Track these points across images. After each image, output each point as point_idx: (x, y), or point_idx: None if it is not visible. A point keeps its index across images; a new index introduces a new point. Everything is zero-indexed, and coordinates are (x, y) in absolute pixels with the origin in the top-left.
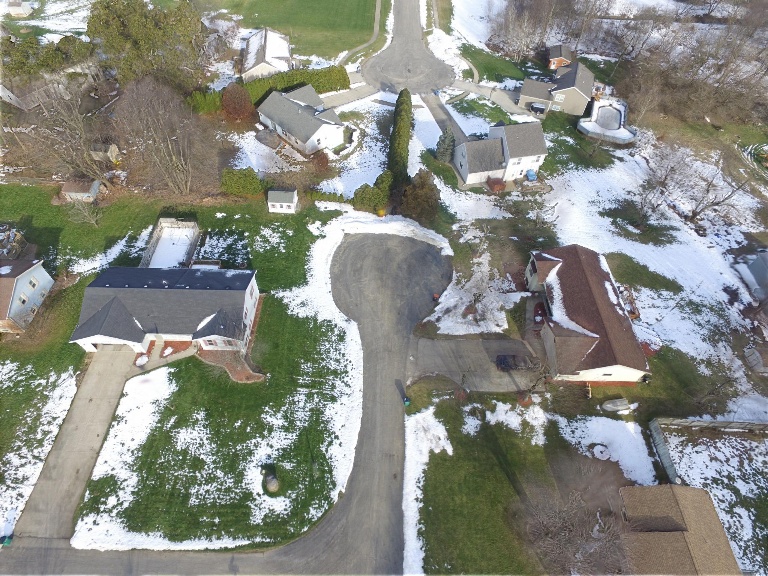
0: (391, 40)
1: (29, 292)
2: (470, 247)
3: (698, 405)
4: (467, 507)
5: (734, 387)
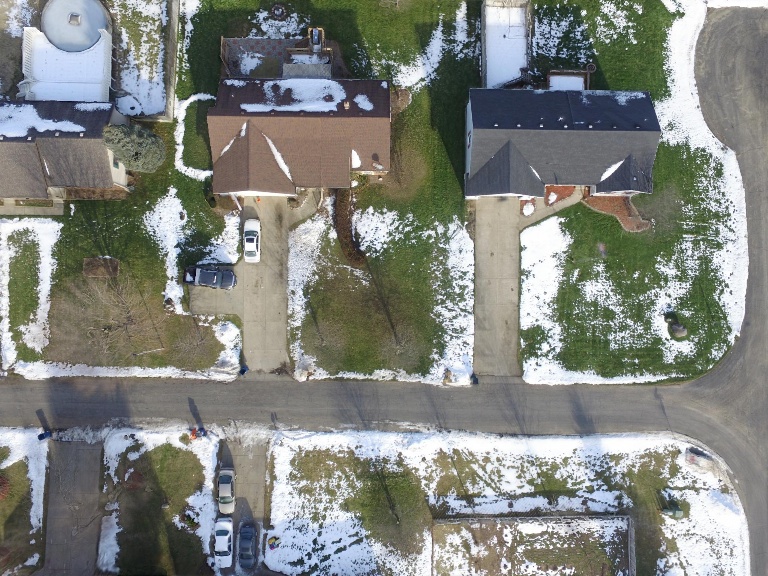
0: None
1: None
2: None
3: None
4: None
5: None
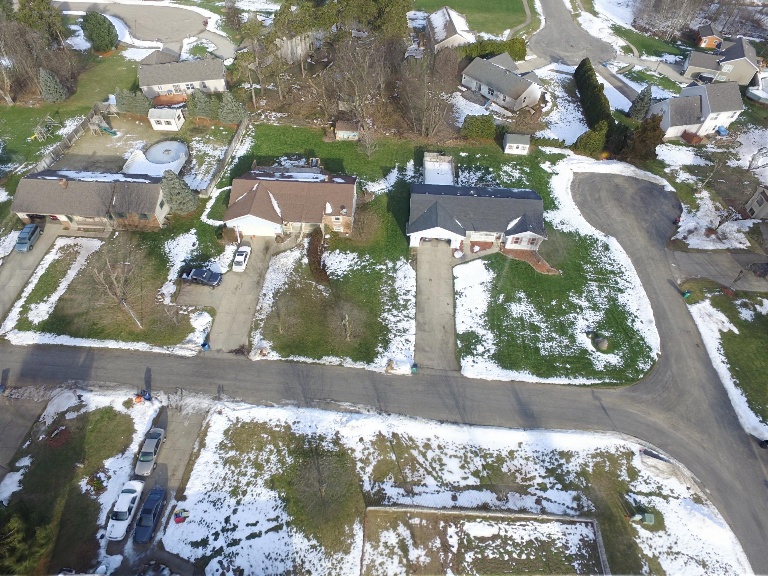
0: (545, 21)
1: (353, 200)
2: (688, 186)
3: None
4: None
5: None
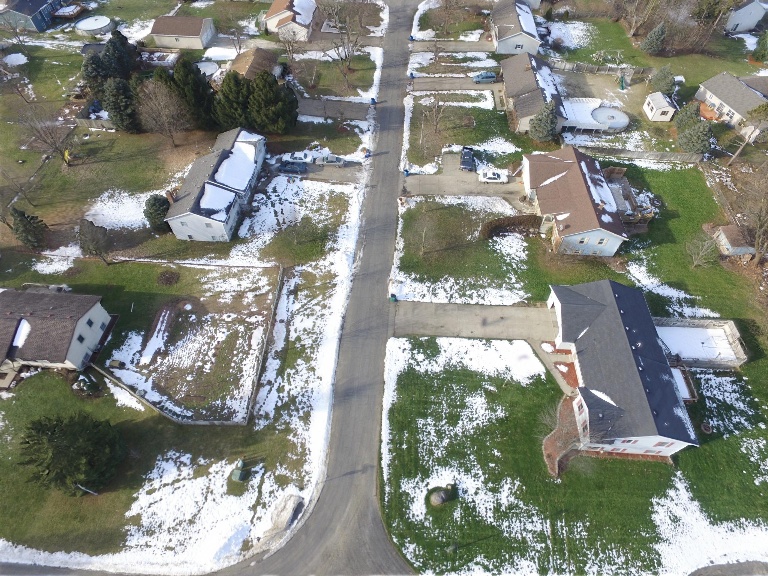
0: None
1: (592, 242)
2: None
3: None
4: None
5: None
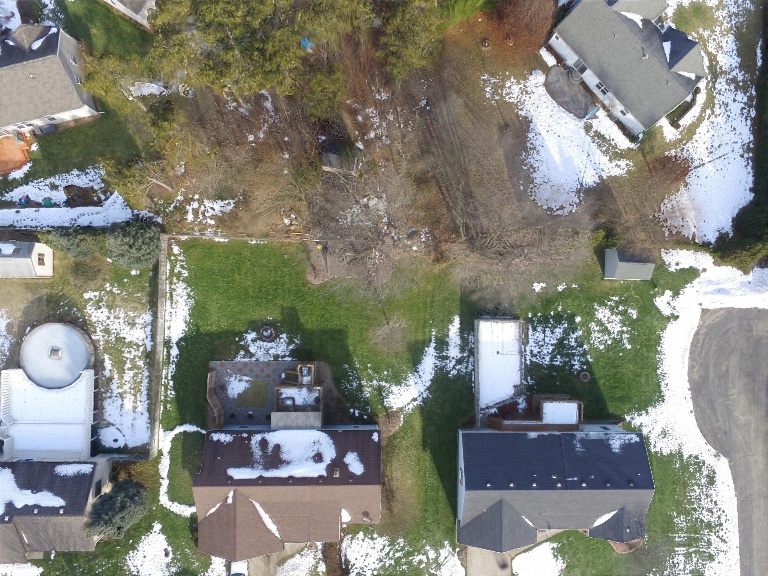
0: None
1: None
2: None
3: None
4: None
5: None
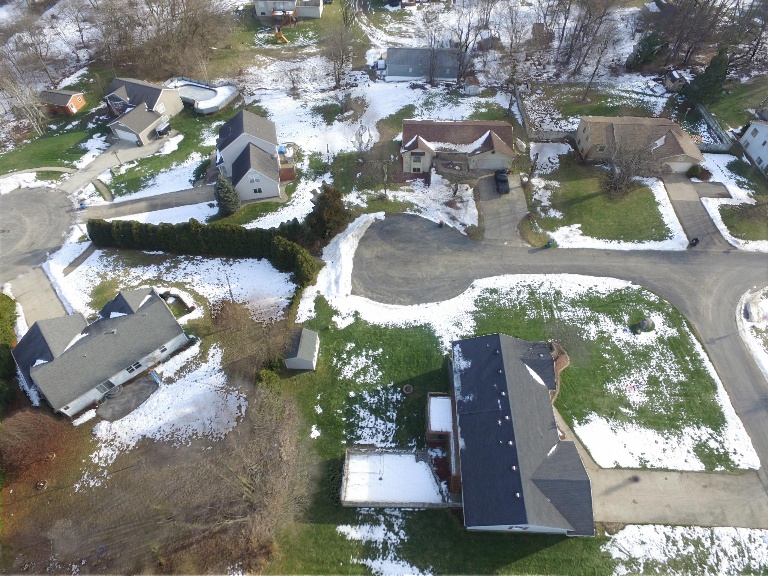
0: None
1: None
2: (373, 201)
3: (511, 117)
4: (614, 219)
5: (493, 103)
